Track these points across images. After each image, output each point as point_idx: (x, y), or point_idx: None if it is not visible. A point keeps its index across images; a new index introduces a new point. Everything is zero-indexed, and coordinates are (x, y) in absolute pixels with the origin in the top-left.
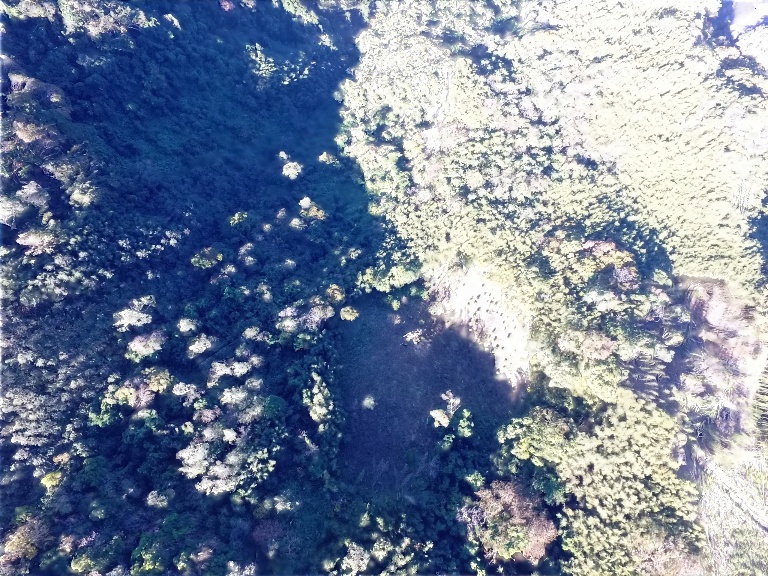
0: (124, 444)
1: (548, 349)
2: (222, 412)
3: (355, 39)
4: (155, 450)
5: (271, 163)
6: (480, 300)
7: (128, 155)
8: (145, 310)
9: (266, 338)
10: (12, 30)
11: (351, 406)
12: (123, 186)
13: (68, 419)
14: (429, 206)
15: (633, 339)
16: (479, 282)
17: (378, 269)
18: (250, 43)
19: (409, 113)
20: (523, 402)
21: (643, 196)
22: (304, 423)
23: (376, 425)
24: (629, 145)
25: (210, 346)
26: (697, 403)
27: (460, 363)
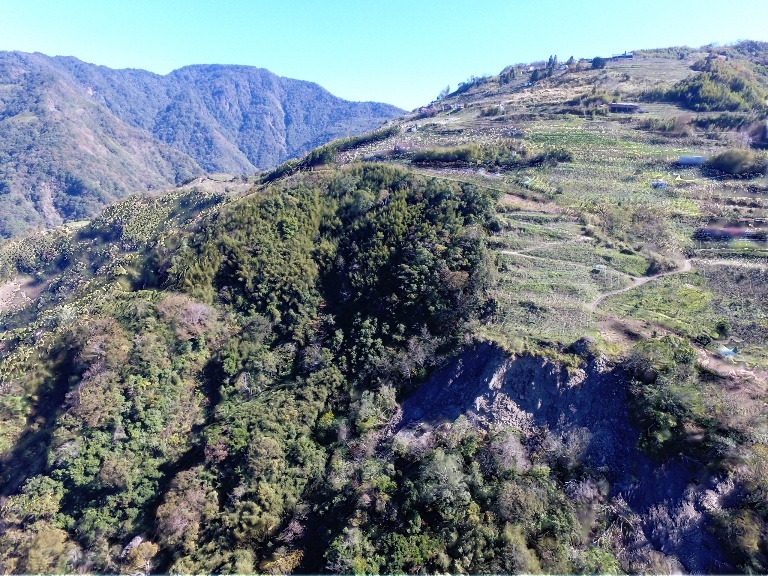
0: None
1: None
2: None
3: None
4: None
5: None
6: None
7: None
8: None
9: None
10: None
11: None
12: None
13: None
14: None
15: None
16: None
17: (8, 316)
18: None
19: None
20: None
21: None
22: None
23: None
24: None
25: None
26: None
27: None
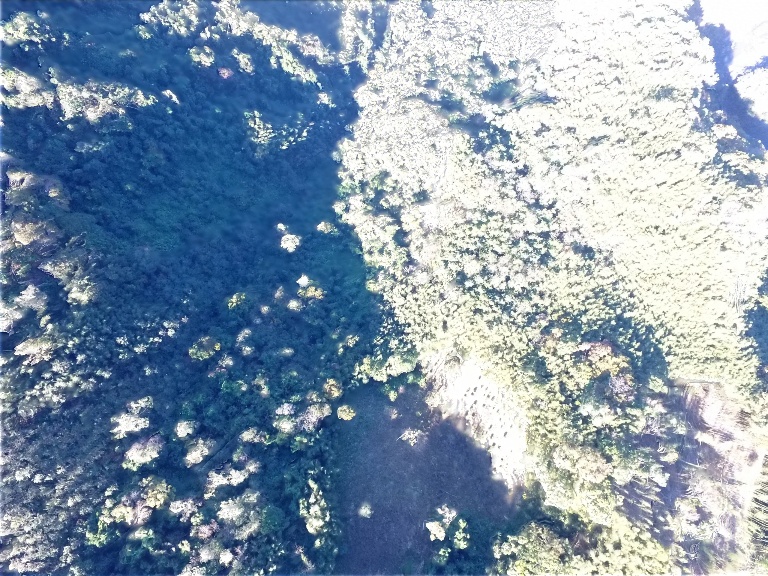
0: (121, 563)
1: (544, 465)
2: (219, 527)
3: (354, 93)
4: (152, 570)
5: (269, 231)
6: (477, 393)
7: (126, 237)
8: (143, 411)
9: (263, 439)
10: (11, 119)
11: (348, 512)
12: (121, 277)
13: (65, 538)
14: (426, 289)
15: (628, 460)
16: (476, 374)
17: (375, 359)
18: (249, 109)
19: (407, 181)
20: (519, 508)
21: (639, 289)
22: (301, 533)
23: (372, 533)
24: (626, 235)
25: (207, 453)
26: (691, 531)
27: (457, 458)
